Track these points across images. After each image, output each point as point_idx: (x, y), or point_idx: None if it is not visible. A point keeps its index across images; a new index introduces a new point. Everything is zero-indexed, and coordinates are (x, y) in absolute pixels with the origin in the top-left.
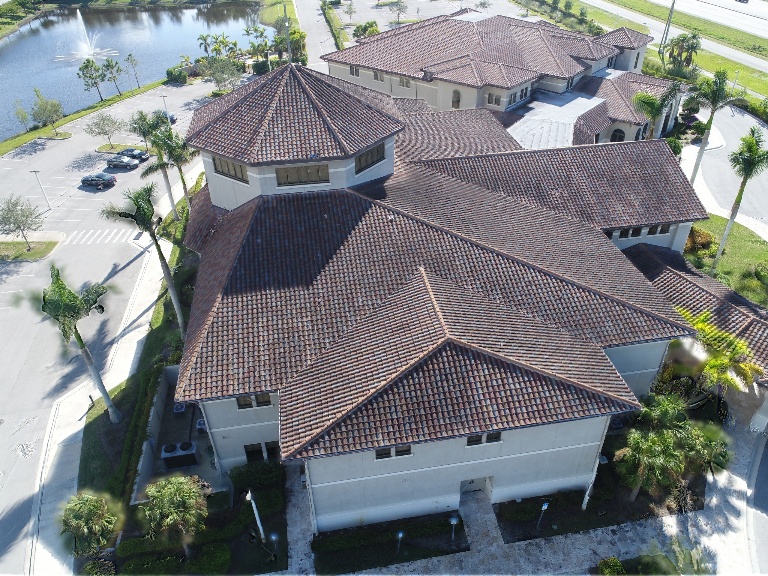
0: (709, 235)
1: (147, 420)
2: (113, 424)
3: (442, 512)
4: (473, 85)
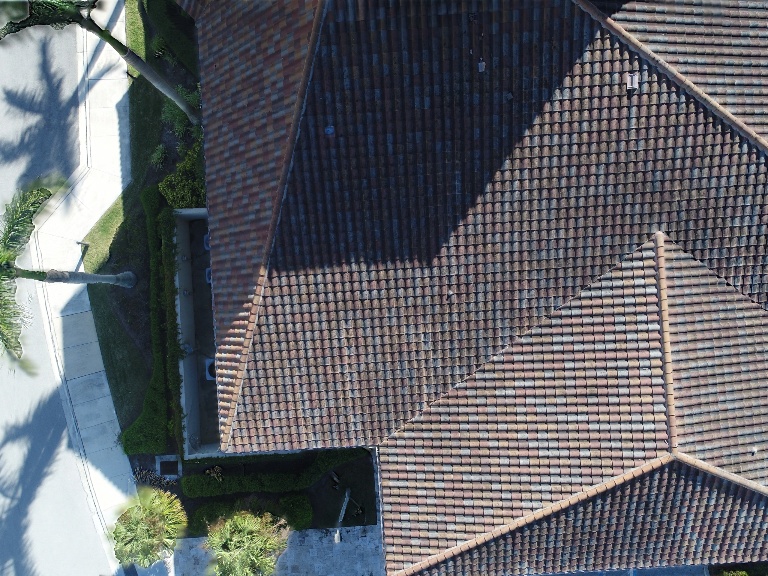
0: None
1: (175, 322)
2: (126, 288)
3: None
4: None
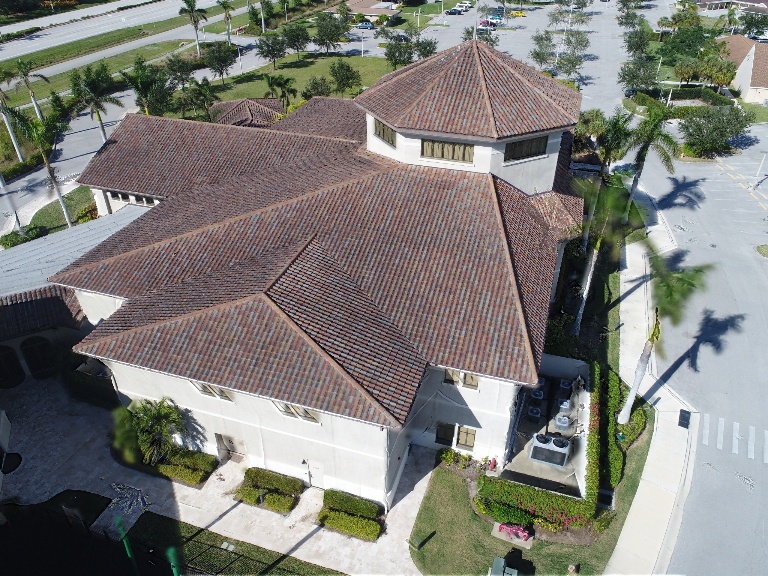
0: (95, 202)
1: None
2: None
3: None
4: None
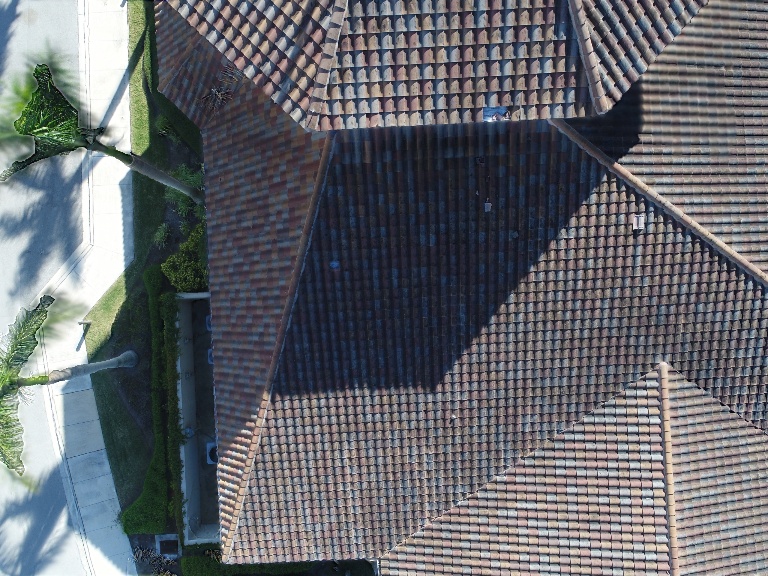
0: None
1: (176, 407)
2: (127, 367)
3: None
4: None
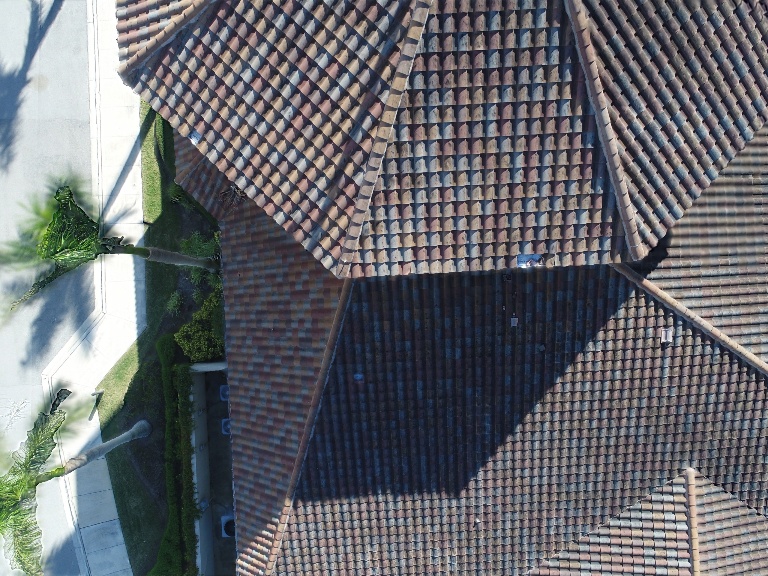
0: None
1: (191, 481)
2: None
3: None
4: None
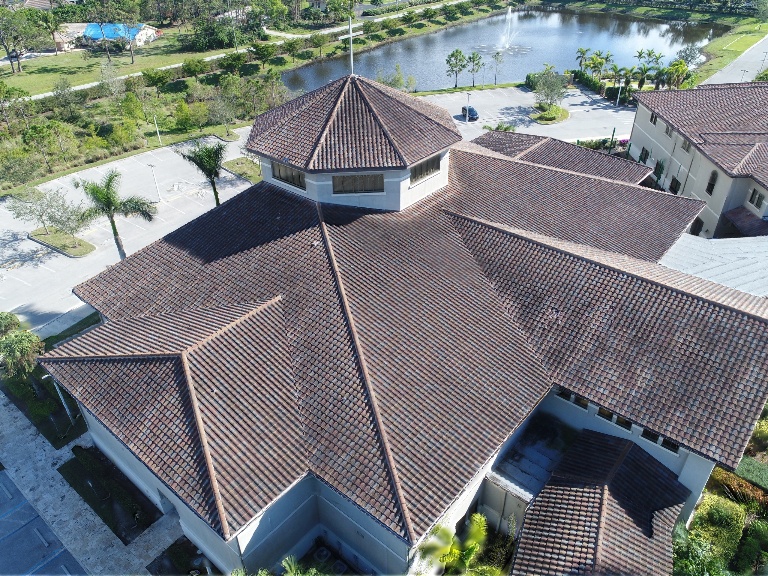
0: None
1: None
2: None
3: (156, 506)
4: (726, 170)
